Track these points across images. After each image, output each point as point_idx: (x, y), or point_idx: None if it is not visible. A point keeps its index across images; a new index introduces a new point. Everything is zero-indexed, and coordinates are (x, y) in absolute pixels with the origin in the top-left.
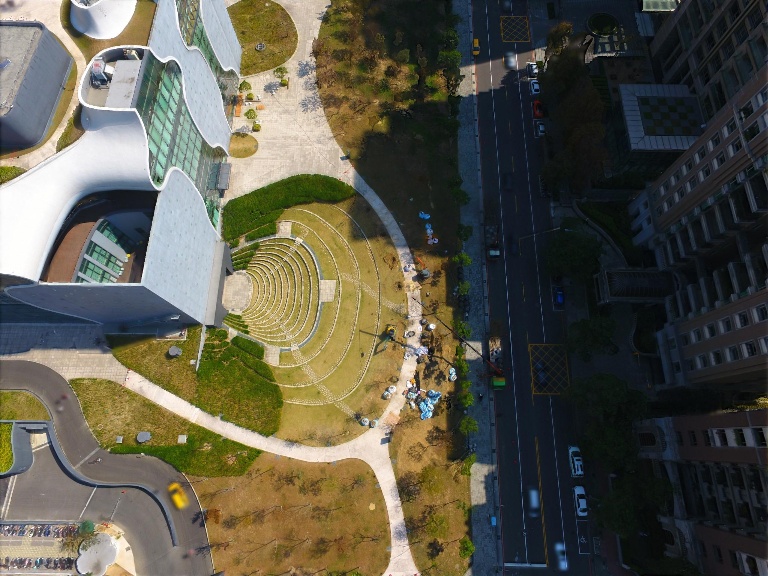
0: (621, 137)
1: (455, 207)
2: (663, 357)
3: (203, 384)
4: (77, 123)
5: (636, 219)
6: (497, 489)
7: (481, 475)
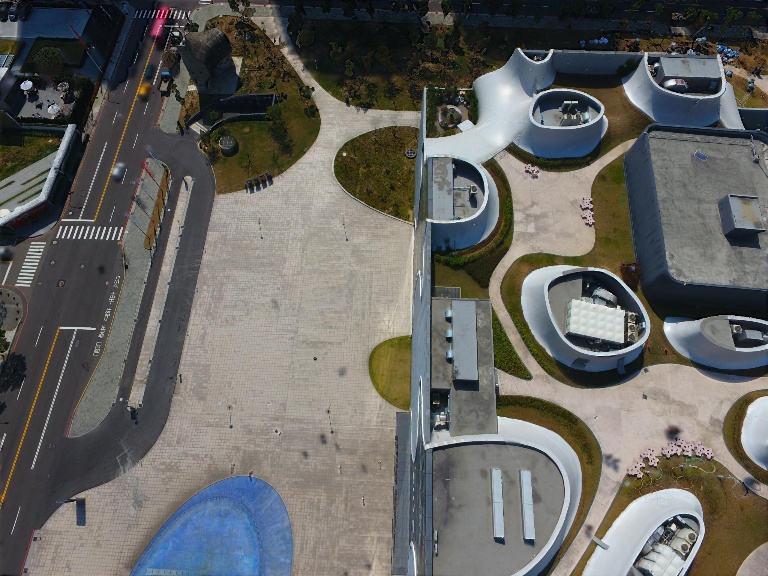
0: None
1: None
2: None
3: None
4: None
5: None
6: (764, 28)
7: (759, 34)
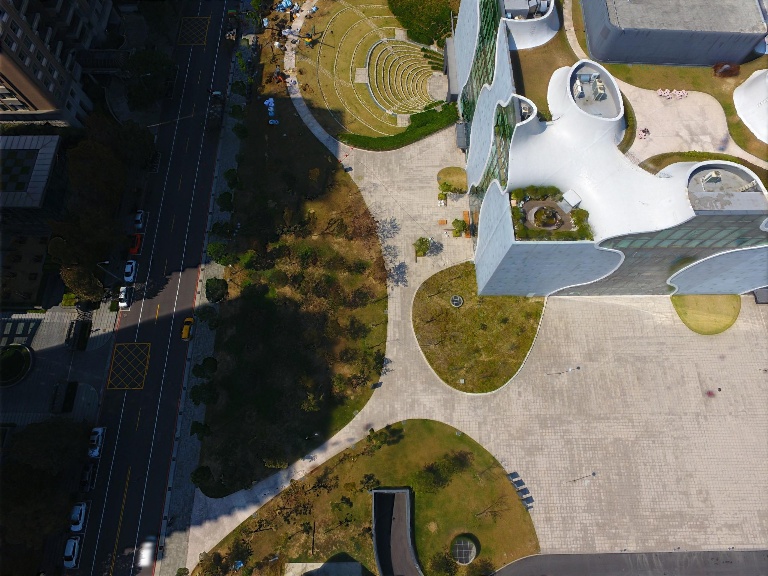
0: (61, 175)
1: None
2: None
3: (445, 5)
4: None
5: None
6: None
7: None
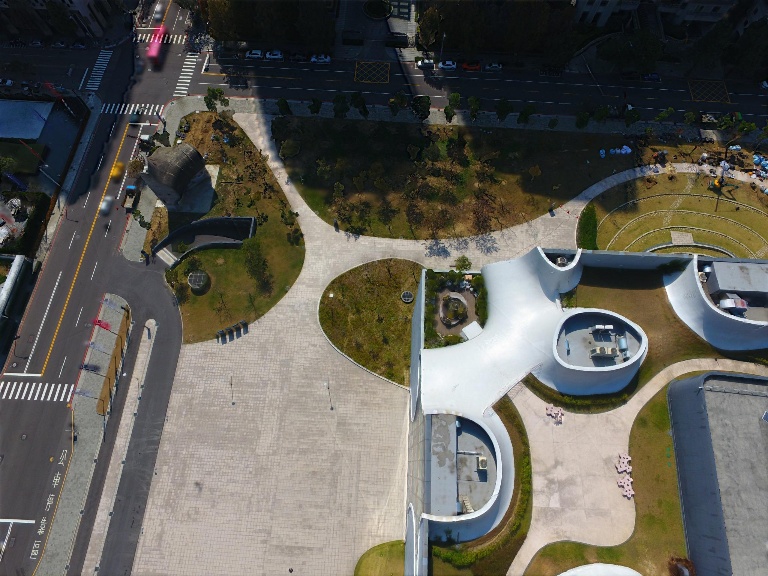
0: None
1: (605, 123)
2: (704, 18)
3: None
4: None
5: (589, 17)
6: None
7: None
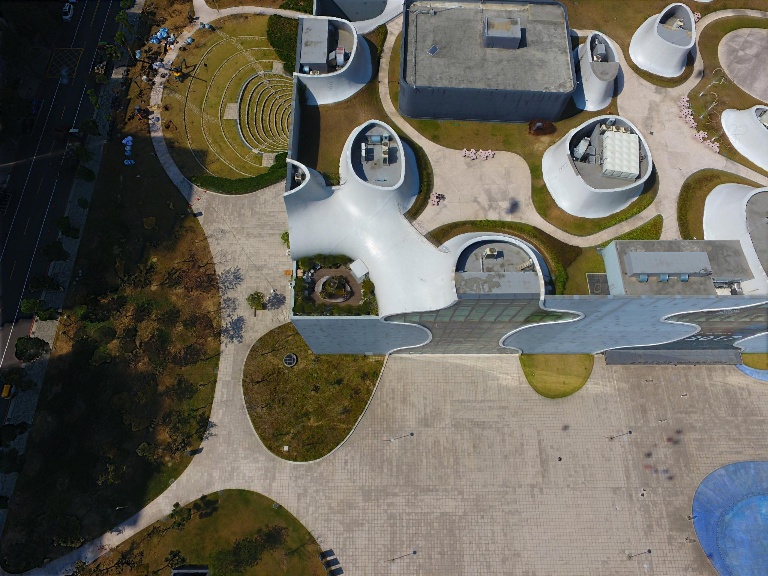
0: None
1: (93, 153)
2: None
3: None
4: (373, 46)
5: None
6: None
7: (136, 7)
